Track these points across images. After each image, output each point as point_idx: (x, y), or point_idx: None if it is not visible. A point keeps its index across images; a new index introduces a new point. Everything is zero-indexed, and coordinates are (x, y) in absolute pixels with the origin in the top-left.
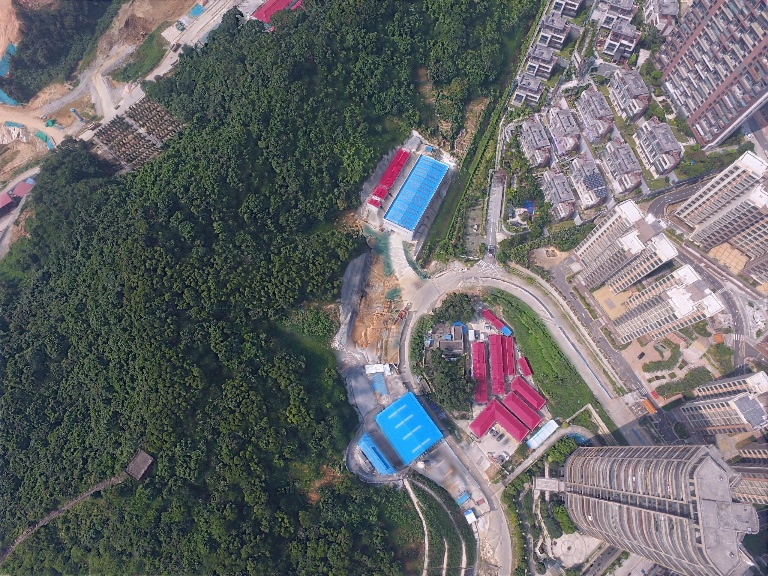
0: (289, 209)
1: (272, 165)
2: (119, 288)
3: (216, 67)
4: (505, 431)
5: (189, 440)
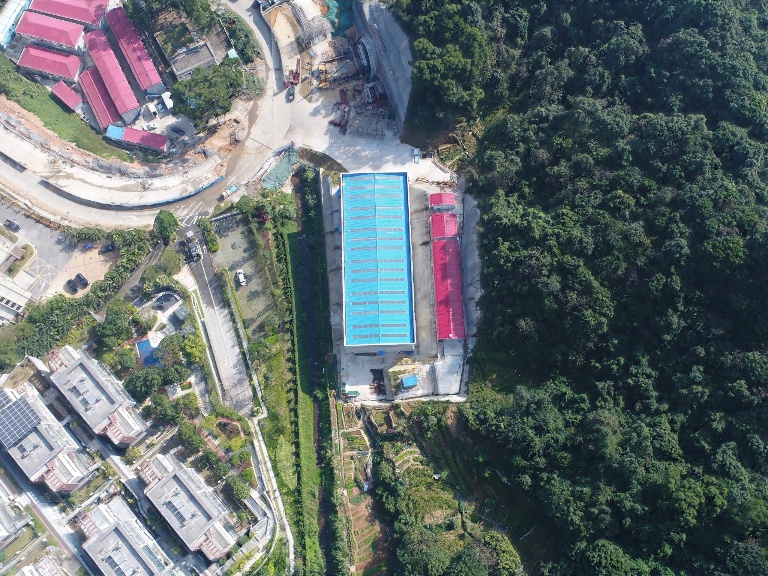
0: (571, 91)
1: None
2: None
3: None
4: None
5: None
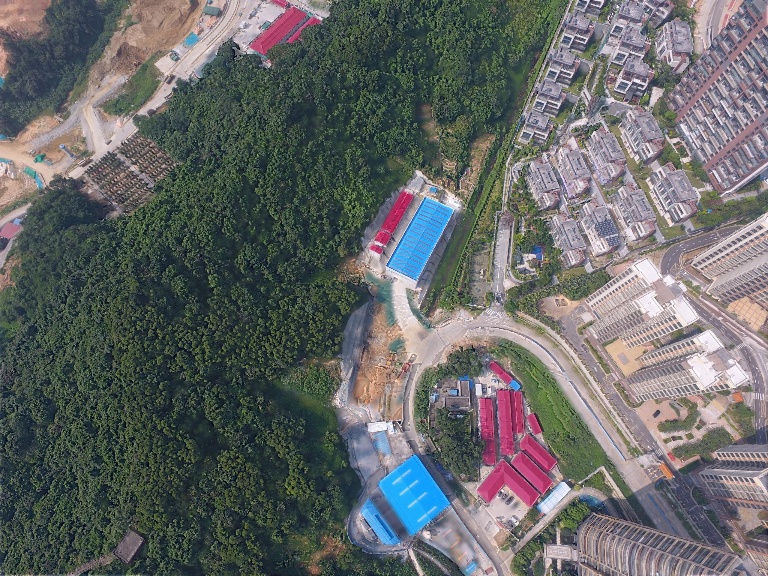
0: (287, 258)
1: (270, 212)
2: (108, 350)
3: (211, 104)
4: (514, 494)
5: (182, 519)
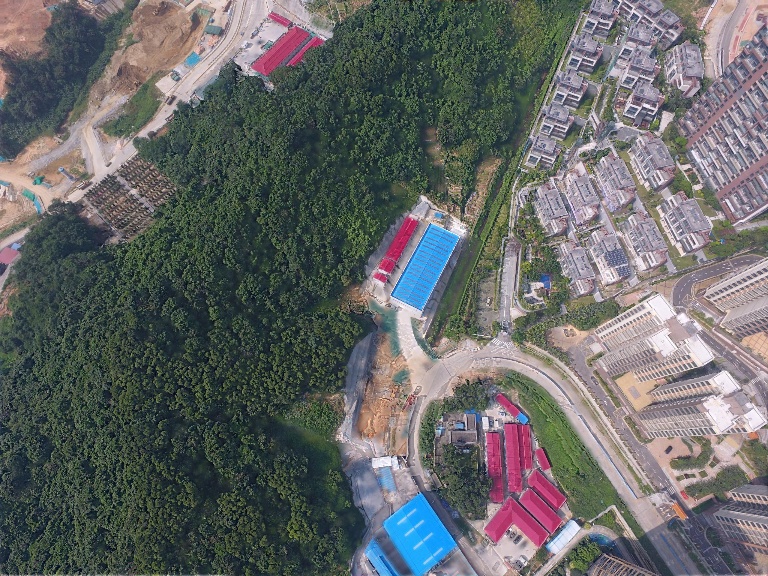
0: (290, 287)
1: (272, 241)
2: (106, 387)
3: (212, 128)
4: (523, 533)
5: (181, 567)
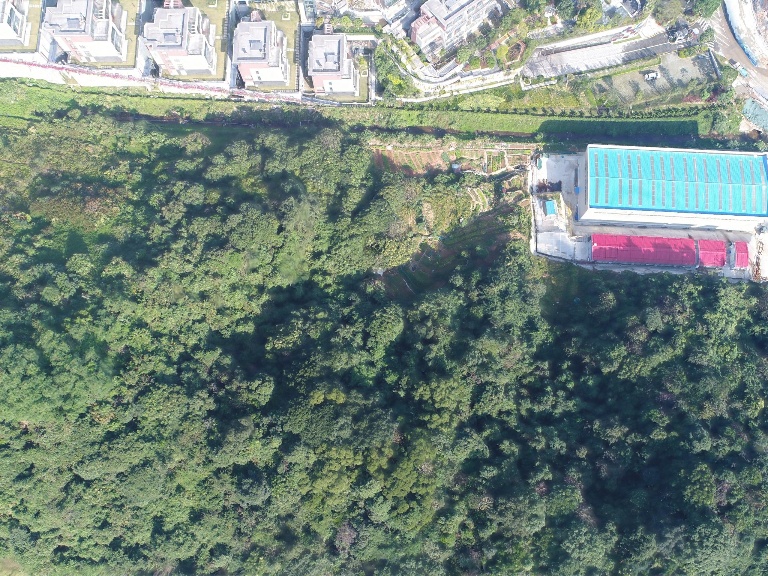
0: None
1: None
2: None
3: None
4: None
5: None
